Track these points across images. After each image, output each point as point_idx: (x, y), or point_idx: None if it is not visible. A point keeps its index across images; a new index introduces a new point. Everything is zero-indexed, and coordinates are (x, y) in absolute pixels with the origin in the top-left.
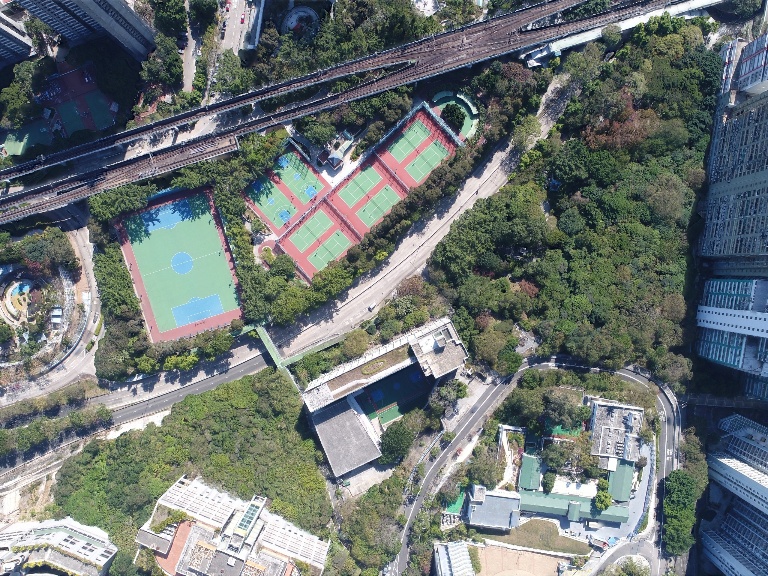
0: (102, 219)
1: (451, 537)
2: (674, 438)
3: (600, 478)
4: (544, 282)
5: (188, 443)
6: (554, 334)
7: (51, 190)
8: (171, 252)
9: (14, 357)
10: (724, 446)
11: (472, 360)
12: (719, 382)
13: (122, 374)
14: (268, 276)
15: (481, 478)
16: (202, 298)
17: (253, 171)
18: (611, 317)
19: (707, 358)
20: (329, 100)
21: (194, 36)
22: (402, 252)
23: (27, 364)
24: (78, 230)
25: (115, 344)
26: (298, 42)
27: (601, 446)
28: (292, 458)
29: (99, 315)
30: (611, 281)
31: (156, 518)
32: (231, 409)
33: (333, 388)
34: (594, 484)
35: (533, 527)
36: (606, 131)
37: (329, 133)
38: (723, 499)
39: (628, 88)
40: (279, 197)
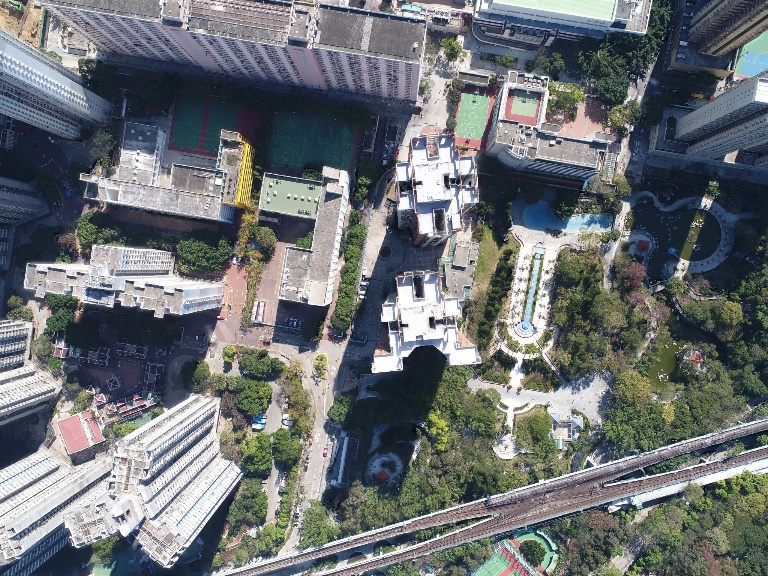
0: None
1: None
2: None
3: None
4: None
5: None
6: None
7: None
8: None
9: None
10: None
11: None
12: None
13: None
14: None
15: None
16: None
17: None
18: None
19: None
20: (413, 550)
21: (277, 466)
22: None
23: None
24: None
25: None
26: (383, 496)
27: None
28: None
29: None
30: None
31: None
32: None
33: None
34: None
35: None
36: None
37: None
38: None
39: (709, 542)
40: None
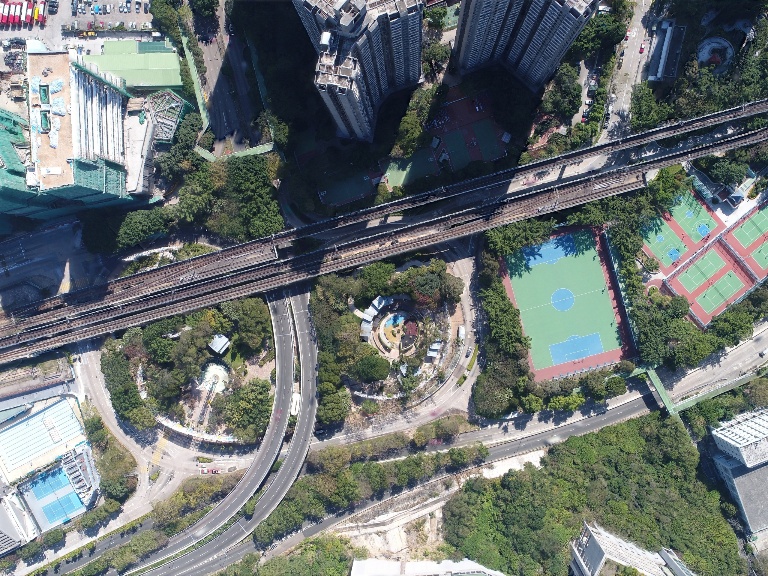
0: (501, 254)
1: None
2: None
3: None
4: None
5: (583, 488)
6: None
7: (444, 222)
8: (552, 288)
9: (389, 390)
10: None
11: None
12: None
13: None
14: (665, 318)
15: None
16: (582, 336)
17: (658, 209)
18: None
19: None
20: (747, 137)
21: (587, 65)
22: None
23: (404, 398)
24: (455, 262)
25: (500, 382)
26: (719, 76)
27: None
28: (696, 509)
29: (472, 350)
30: None
31: (603, 573)
32: (622, 454)
33: None
34: None
35: None
36: None
37: (745, 172)
38: None
39: None
40: (669, 235)
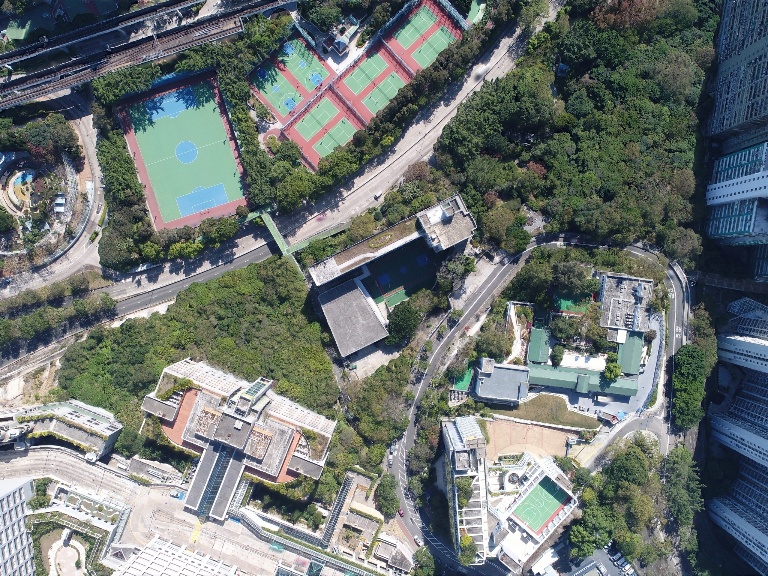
0: (106, 101)
1: (459, 411)
2: (683, 315)
3: (609, 352)
4: (552, 161)
5: (193, 327)
6: (563, 210)
7: (54, 74)
8: (175, 141)
9: (17, 246)
10: (733, 329)
11: (480, 239)
12: (728, 262)
13: (126, 263)
14: (273, 161)
15: (489, 350)
16: (207, 187)
17: (258, 54)
18: (620, 191)
19: (716, 238)
20: None
21: None
22: (408, 140)
23: (30, 253)
24: (81, 119)
25: (119, 231)
26: None
27: (610, 318)
28: (298, 341)
29: (103, 205)
30: (620, 158)
31: (162, 387)
32: (236, 295)
33: (340, 262)
34: (603, 359)
35: (542, 401)
36: (615, 12)
37: (335, 14)
38: (732, 382)
39: None
40: (284, 85)
